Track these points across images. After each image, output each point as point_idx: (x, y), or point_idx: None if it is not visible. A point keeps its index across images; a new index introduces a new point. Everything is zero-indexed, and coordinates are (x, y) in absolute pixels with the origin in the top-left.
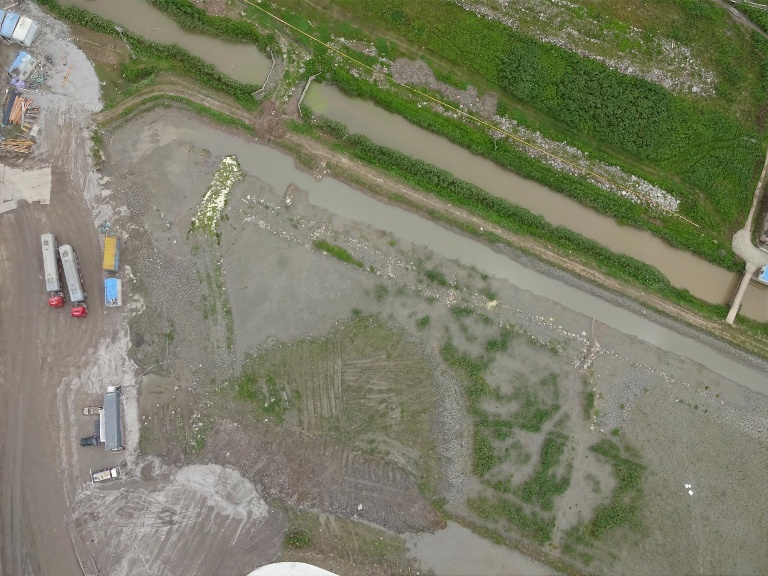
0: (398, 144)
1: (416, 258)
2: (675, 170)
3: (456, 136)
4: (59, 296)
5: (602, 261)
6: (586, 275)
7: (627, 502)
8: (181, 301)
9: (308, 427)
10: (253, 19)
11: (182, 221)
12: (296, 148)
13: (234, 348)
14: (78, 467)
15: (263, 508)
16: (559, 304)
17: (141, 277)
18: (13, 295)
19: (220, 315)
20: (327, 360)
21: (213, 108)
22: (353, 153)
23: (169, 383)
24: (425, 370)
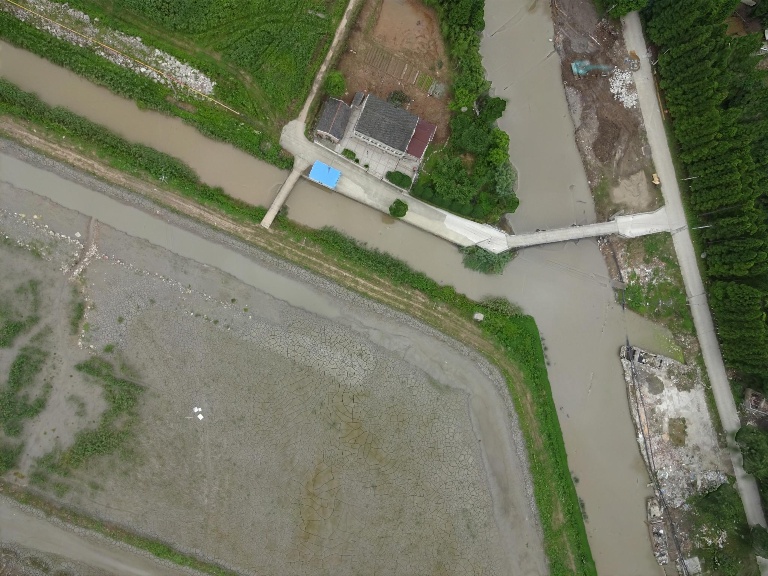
0: None
1: None
2: (213, 45)
3: None
4: None
5: (106, 150)
6: (82, 166)
7: (118, 427)
8: None
9: None
10: None
11: None
12: None
13: None
14: None
15: None
16: (47, 199)
17: None
18: None
19: None
20: None
21: None
22: None
23: None
24: None
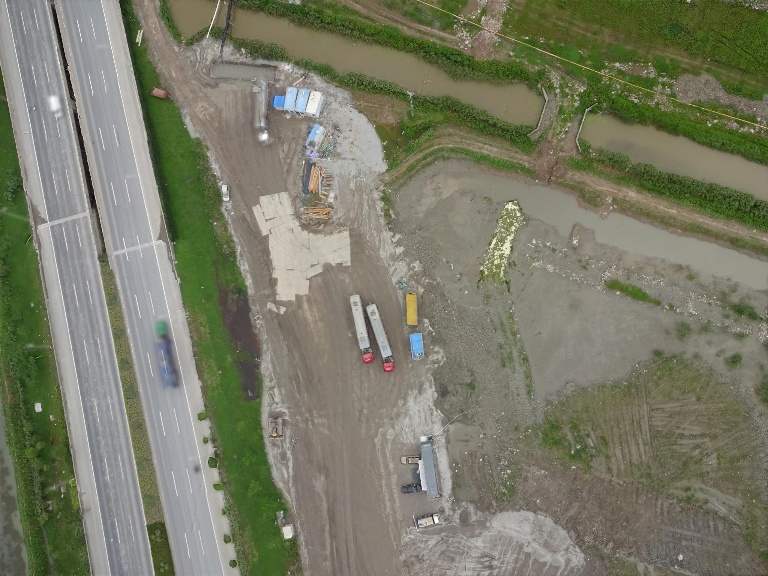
0: (686, 169)
1: (719, 291)
2: None
3: (755, 153)
4: (369, 352)
5: None
6: None
7: None
8: (478, 350)
9: (617, 474)
10: (522, 57)
11: (471, 271)
12: (579, 186)
13: (534, 395)
14: (401, 513)
15: (580, 556)
16: None
17: (439, 329)
18: (328, 353)
19: (517, 363)
20: (632, 405)
21: (492, 155)
22: (640, 185)
23: (474, 431)
24: (740, 413)
